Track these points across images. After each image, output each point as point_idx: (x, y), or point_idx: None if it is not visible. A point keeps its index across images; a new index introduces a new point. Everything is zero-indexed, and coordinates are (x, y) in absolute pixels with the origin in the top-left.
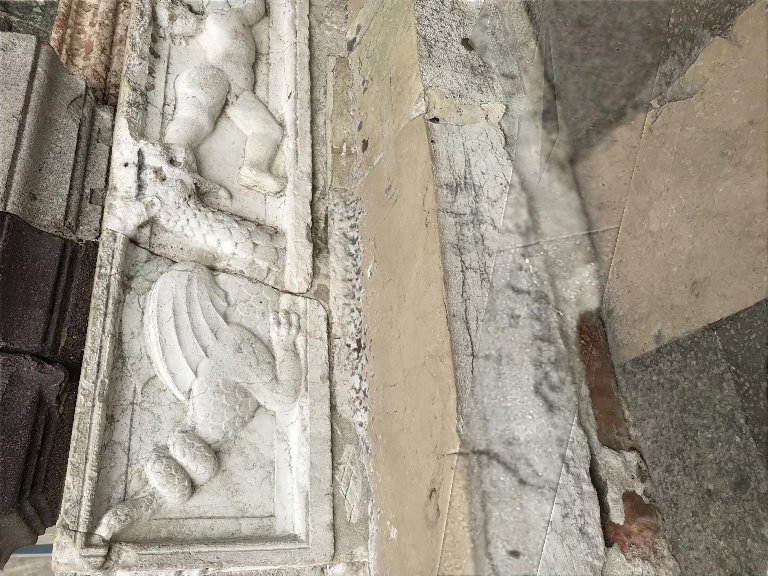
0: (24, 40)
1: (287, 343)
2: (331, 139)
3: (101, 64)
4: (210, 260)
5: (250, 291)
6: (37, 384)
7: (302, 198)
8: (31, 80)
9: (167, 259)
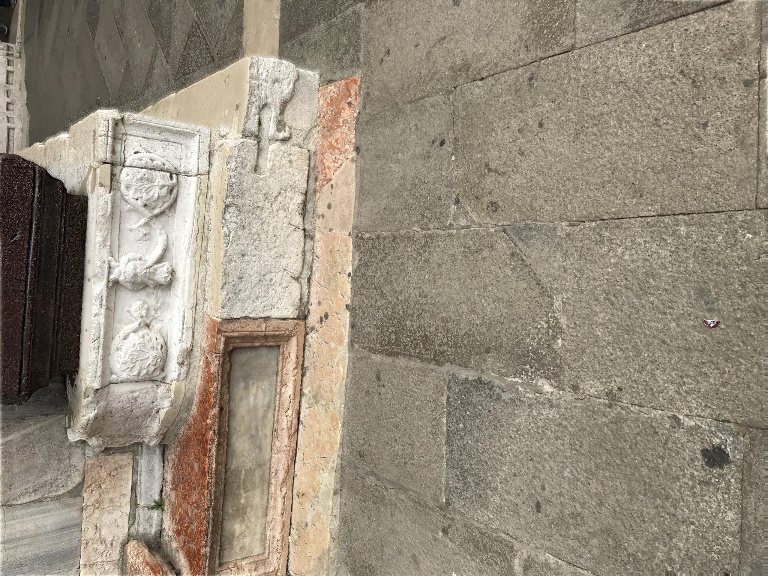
0: None
1: None
2: None
3: None
4: None
5: None
6: None
7: None
8: None
9: None
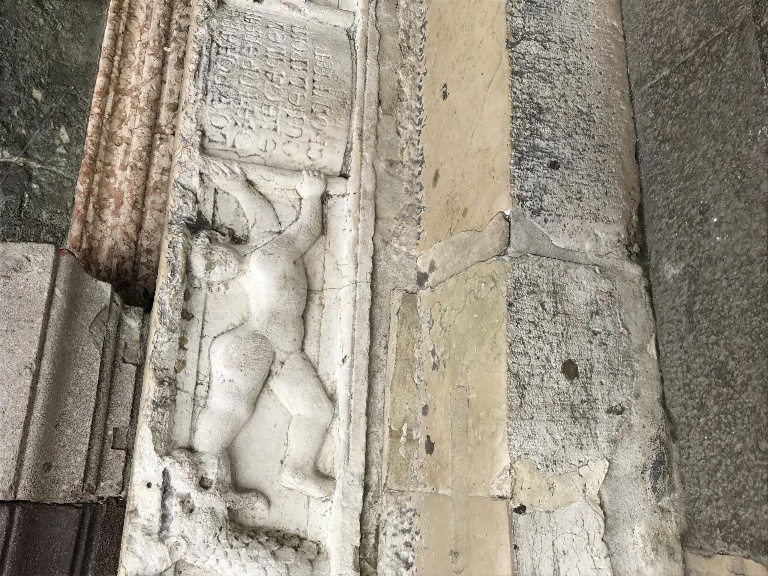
0: (40, 253)
1: None
2: (390, 417)
3: (132, 224)
4: None
5: None
6: None
7: (351, 511)
8: (47, 310)
9: None
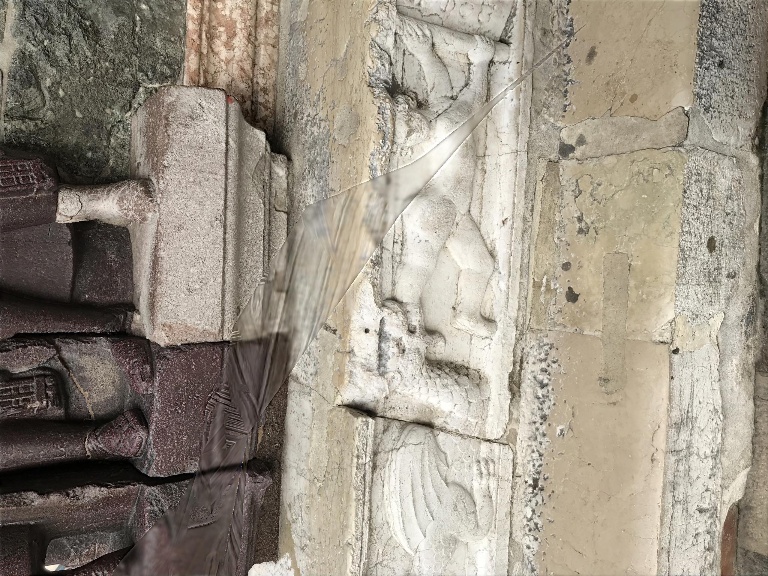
0: (212, 100)
1: (485, 489)
2: (534, 270)
3: (249, 60)
4: (428, 414)
5: (463, 449)
6: (251, 492)
7: (508, 347)
8: (226, 161)
9: (397, 422)
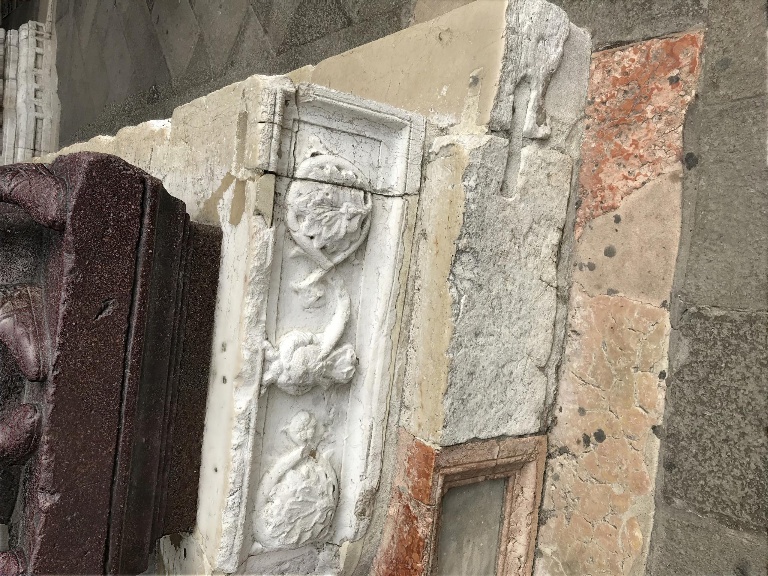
0: None
1: None
2: None
3: None
4: None
5: None
6: None
7: None
8: None
9: None
